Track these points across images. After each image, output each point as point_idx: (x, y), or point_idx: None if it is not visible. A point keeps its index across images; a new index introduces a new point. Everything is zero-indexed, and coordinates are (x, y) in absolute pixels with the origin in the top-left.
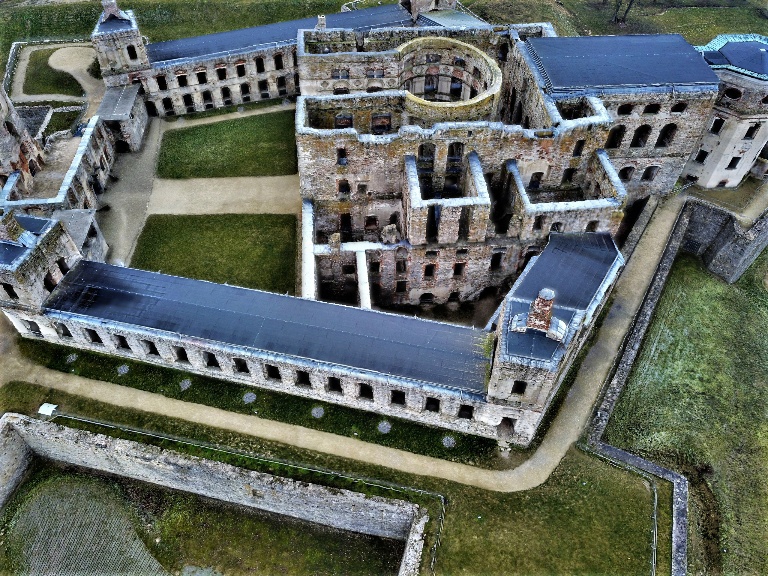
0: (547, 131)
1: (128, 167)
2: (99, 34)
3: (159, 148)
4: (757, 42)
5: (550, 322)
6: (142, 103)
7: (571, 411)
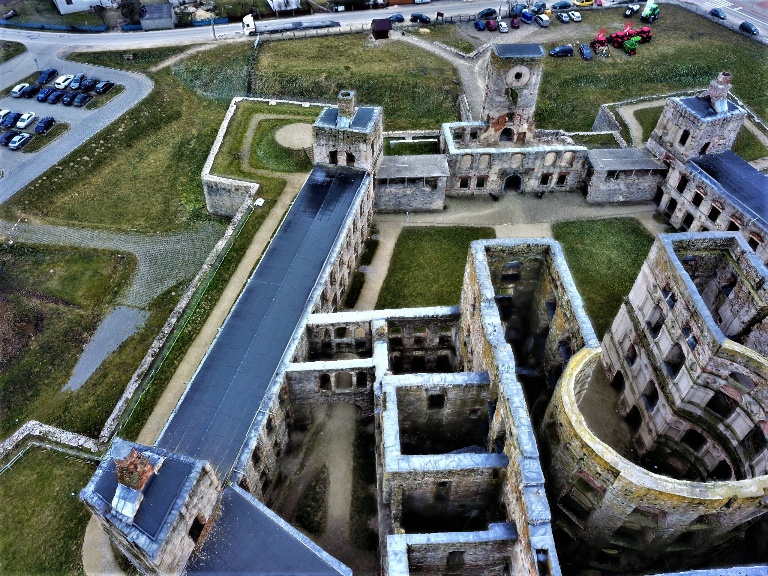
0: (555, 575)
1: (561, 202)
2: (676, 101)
3: (601, 218)
4: None
5: (130, 488)
6: (653, 183)
7: None
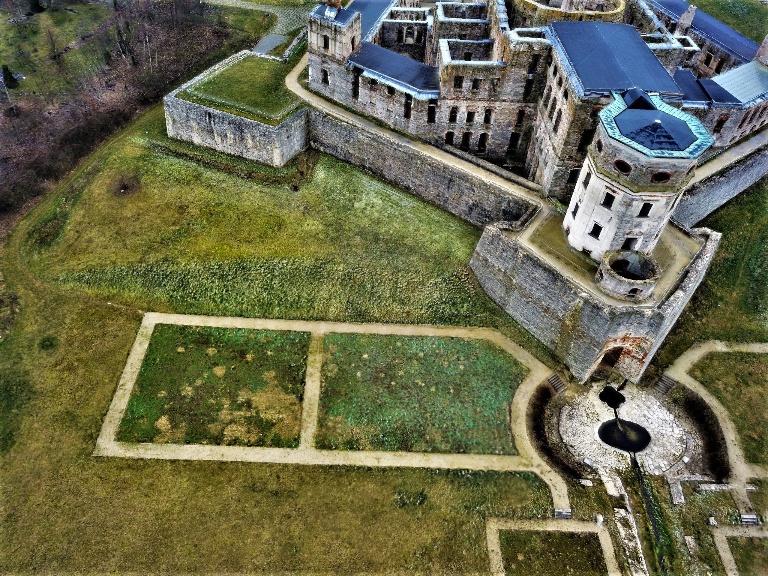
0: None
1: None
2: None
3: None
4: (690, 135)
5: (333, 8)
6: None
7: (328, 106)
